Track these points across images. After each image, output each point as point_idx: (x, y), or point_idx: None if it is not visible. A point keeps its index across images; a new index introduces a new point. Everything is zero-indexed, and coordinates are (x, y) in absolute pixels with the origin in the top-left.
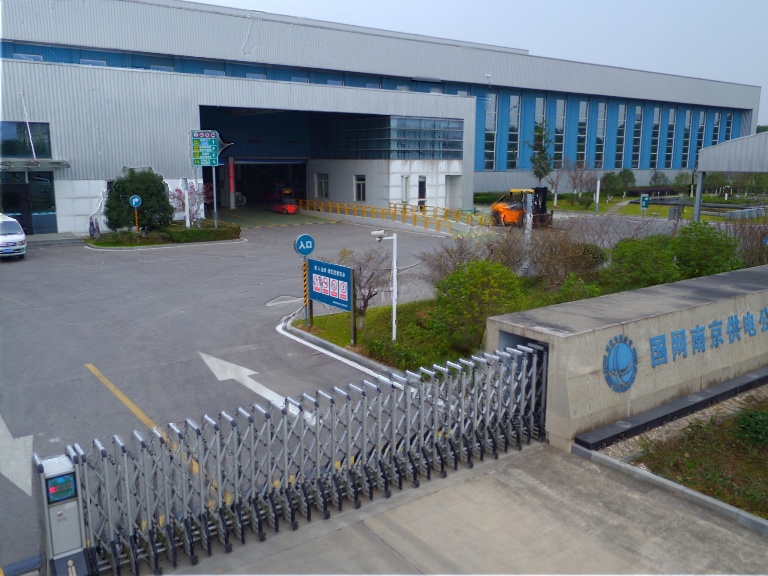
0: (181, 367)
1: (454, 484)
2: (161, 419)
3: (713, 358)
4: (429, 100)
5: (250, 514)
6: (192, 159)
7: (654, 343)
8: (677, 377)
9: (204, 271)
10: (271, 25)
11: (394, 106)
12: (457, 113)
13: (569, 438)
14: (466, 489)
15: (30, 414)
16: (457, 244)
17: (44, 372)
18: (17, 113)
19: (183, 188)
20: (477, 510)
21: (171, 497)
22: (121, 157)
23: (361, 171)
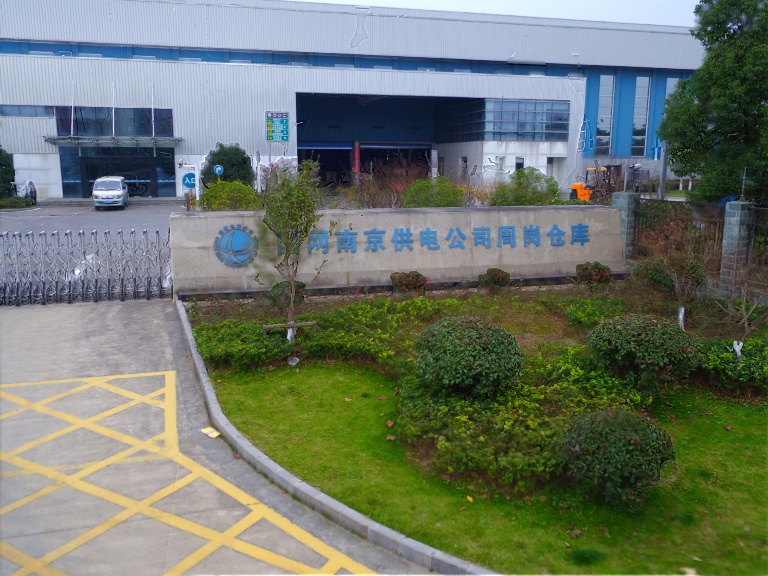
0: None
1: (67, 306)
2: None
3: (368, 260)
4: (529, 82)
5: None
6: (266, 136)
7: None
8: (313, 268)
9: None
10: (396, 20)
11: (489, 89)
12: (562, 95)
13: (173, 292)
14: (68, 308)
15: None
16: None
17: None
18: (149, 101)
19: None
20: (50, 315)
21: None
22: (228, 136)
23: (464, 153)
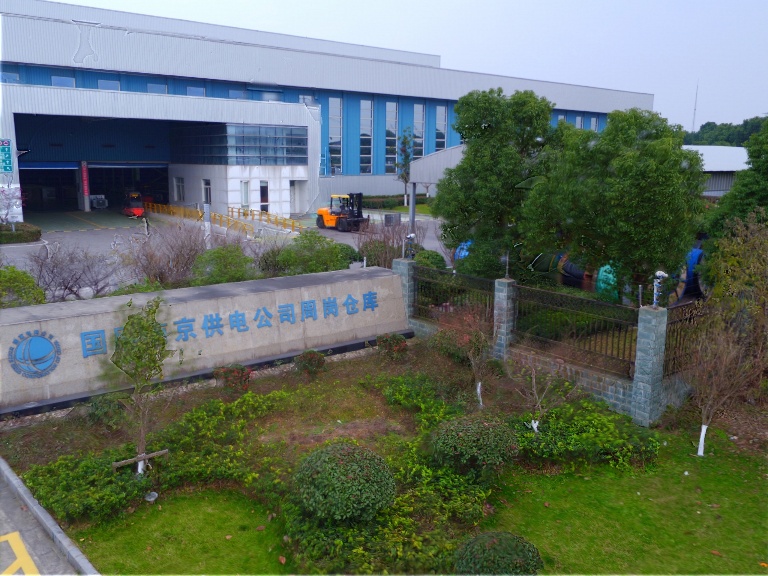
0: None
1: None
2: None
3: None
4: (268, 108)
5: None
6: None
7: (87, 337)
8: None
9: None
10: (121, 34)
11: (230, 114)
12: (300, 121)
13: None
14: None
15: None
16: (39, 251)
17: None
18: None
19: None
20: None
21: None
22: None
23: (207, 176)
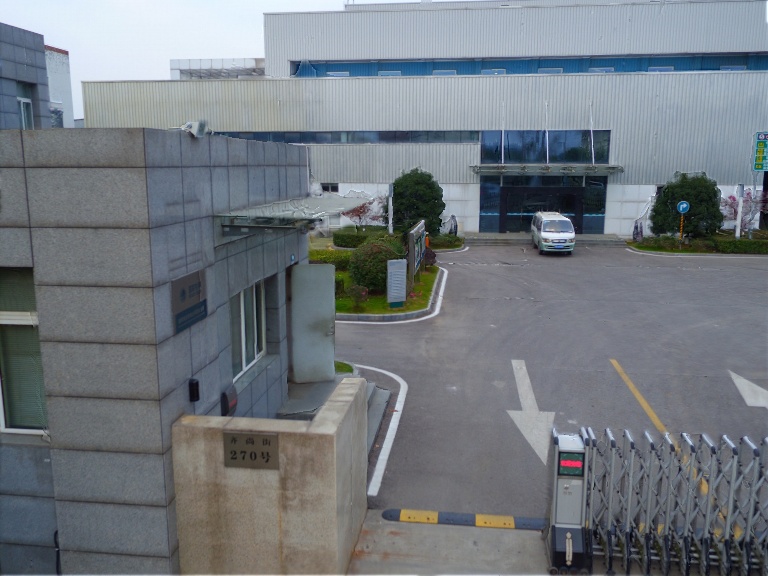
0: (706, 382)
1: None
2: (676, 429)
3: None
4: None
5: (761, 559)
6: (753, 164)
7: None
8: None
9: (749, 286)
10: None
11: None
12: None
13: None
14: None
15: (555, 393)
16: None
17: (573, 359)
18: (584, 122)
19: (738, 195)
20: None
21: (673, 509)
22: (675, 162)
23: None
